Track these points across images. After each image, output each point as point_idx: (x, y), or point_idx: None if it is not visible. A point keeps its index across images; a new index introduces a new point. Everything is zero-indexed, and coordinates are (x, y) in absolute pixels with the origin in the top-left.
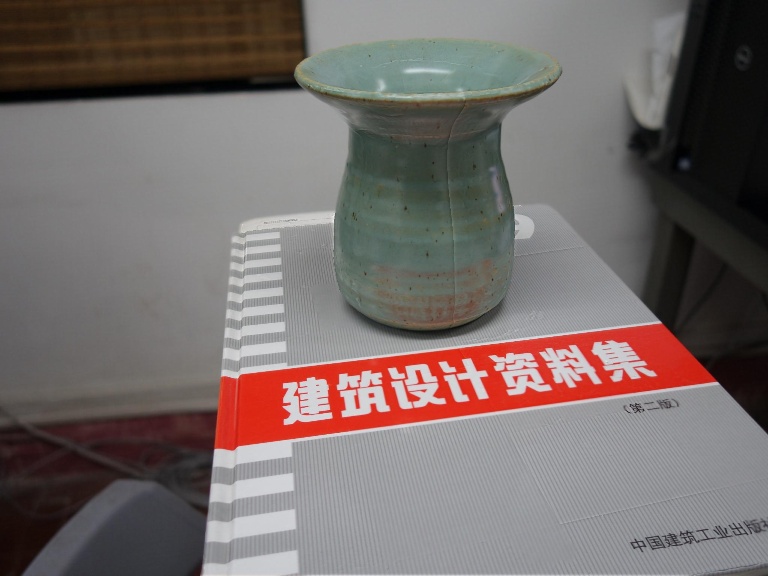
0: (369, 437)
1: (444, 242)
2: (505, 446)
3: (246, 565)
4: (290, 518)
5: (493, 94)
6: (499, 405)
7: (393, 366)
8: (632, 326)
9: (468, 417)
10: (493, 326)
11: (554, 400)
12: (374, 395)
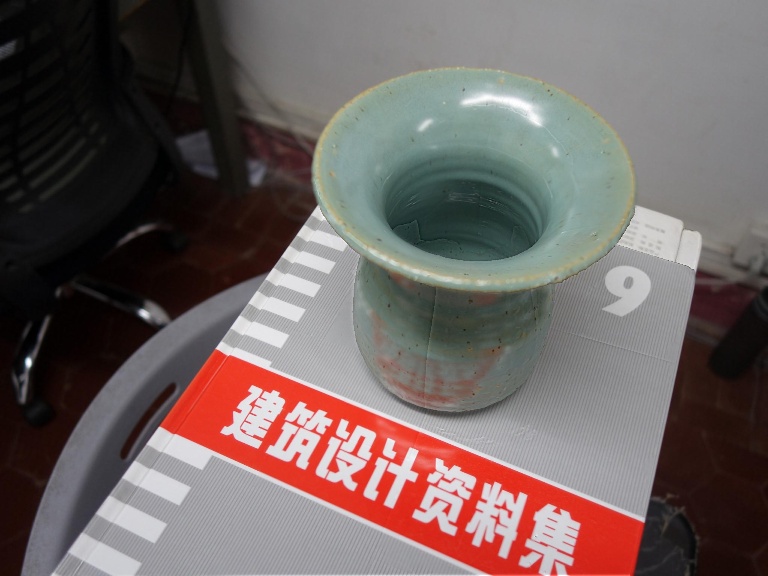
0: (268, 488)
1: (417, 353)
2: (359, 571)
3: (104, 553)
4: (158, 531)
5: (454, 284)
6: (394, 523)
7: (348, 419)
8: (608, 506)
9: (358, 519)
10: (473, 422)
11: (445, 549)
12: (307, 443)
